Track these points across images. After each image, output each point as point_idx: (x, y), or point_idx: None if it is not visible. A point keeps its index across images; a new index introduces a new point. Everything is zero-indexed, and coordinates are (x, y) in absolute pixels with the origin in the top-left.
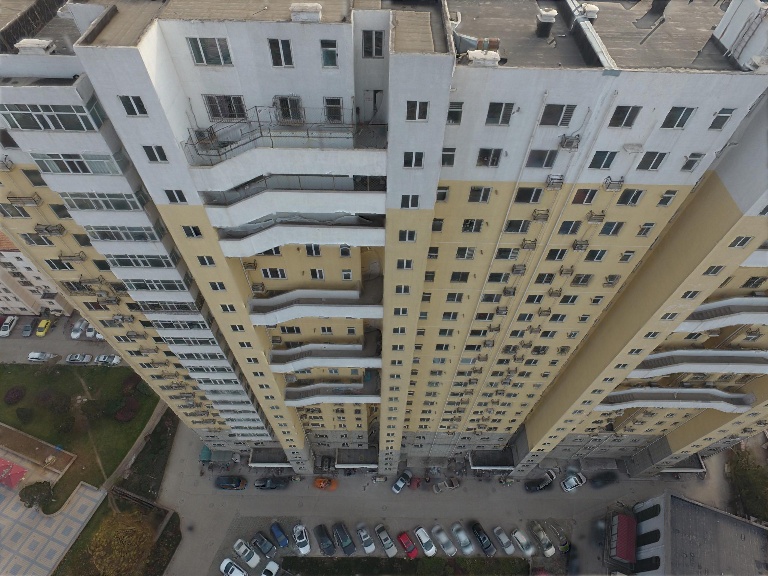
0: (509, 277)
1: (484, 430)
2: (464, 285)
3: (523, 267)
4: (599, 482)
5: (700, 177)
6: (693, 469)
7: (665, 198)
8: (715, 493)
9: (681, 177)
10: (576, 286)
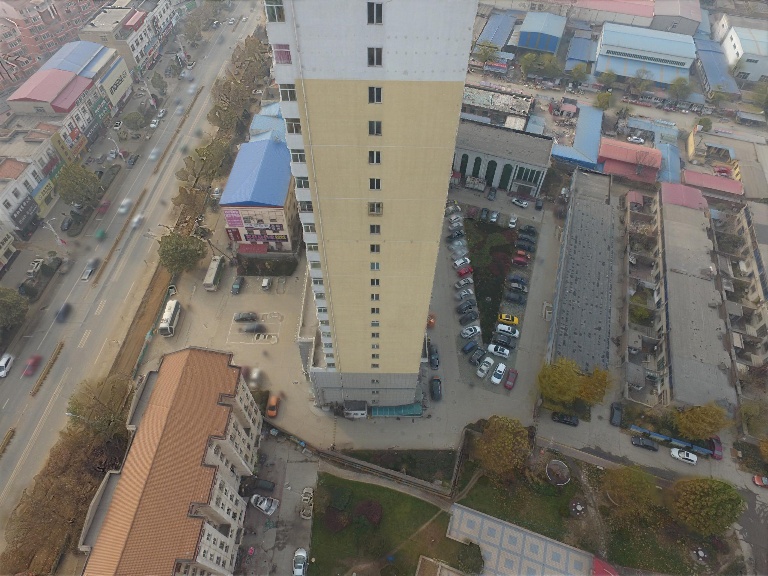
0: None
1: None
2: None
3: None
4: None
5: None
6: None
7: None
8: None
9: None
10: None
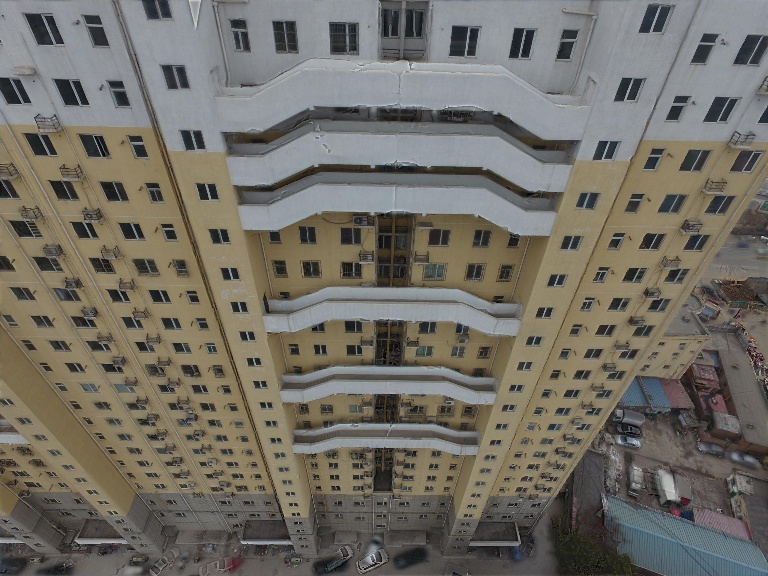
0: (59, 263)
1: (234, 490)
2: (16, 275)
3: (54, 247)
4: (402, 561)
5: (148, 116)
6: (505, 542)
7: (139, 147)
8: (542, 574)
9: (124, 115)
10: (144, 275)
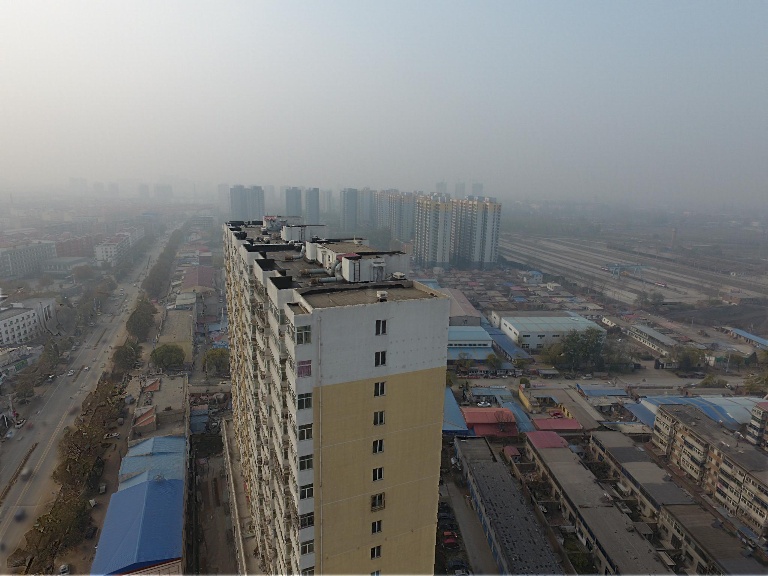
0: None
1: None
2: None
3: None
4: None
5: None
6: None
7: None
8: None
9: None
10: None
